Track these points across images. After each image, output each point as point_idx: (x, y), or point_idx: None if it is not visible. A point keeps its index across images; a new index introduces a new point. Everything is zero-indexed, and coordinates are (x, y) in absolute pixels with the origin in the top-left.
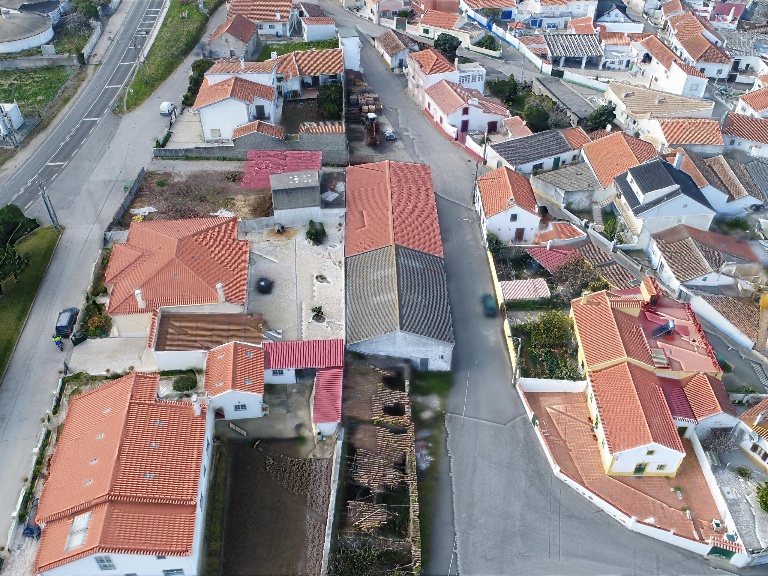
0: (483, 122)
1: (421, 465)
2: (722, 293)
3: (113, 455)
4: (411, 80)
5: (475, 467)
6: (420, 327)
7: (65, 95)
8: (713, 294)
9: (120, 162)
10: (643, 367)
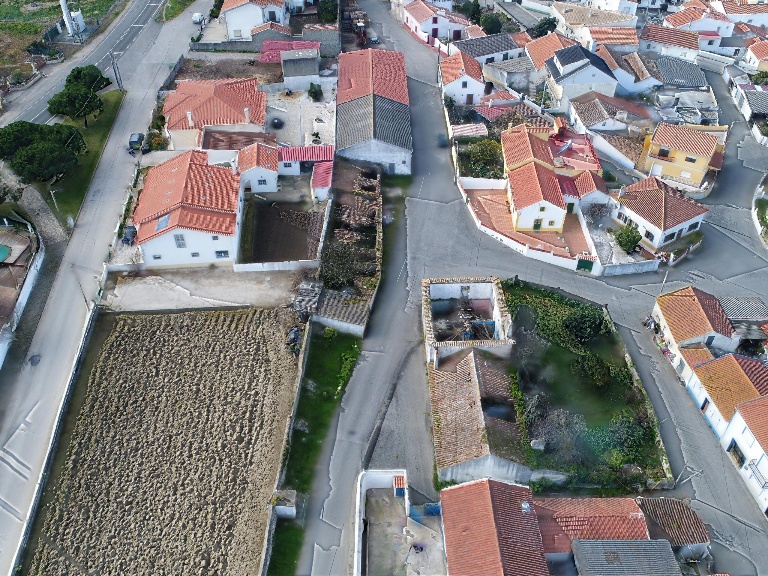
0: (450, 30)
1: (386, 220)
2: (617, 134)
3: (182, 187)
4: (393, 1)
5: (424, 223)
6: (388, 139)
7: (116, 10)
8: (610, 135)
9: (164, 52)
10: (546, 167)
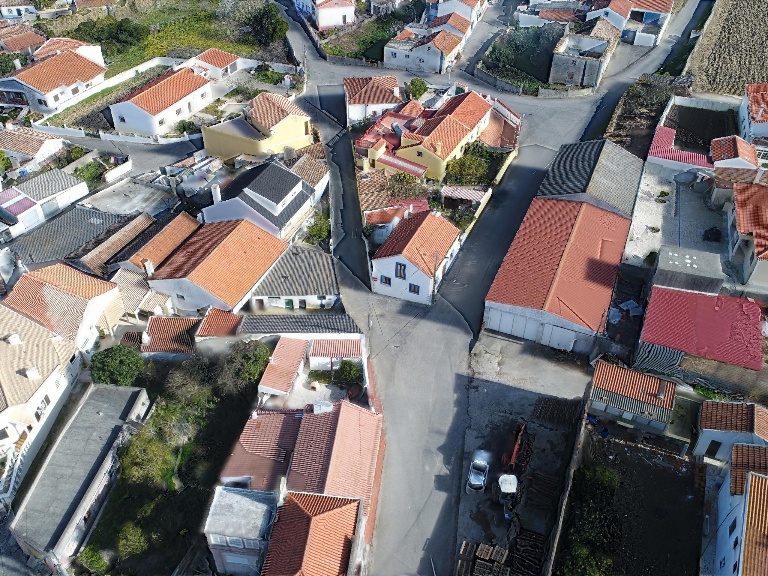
0: None
1: None
2: None
3: None
4: None
5: None
6: None
7: None
8: None
9: None
10: None
